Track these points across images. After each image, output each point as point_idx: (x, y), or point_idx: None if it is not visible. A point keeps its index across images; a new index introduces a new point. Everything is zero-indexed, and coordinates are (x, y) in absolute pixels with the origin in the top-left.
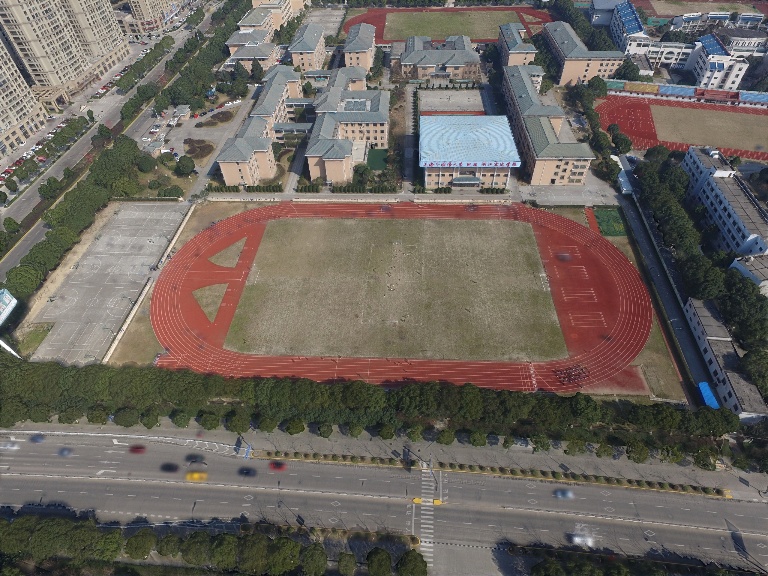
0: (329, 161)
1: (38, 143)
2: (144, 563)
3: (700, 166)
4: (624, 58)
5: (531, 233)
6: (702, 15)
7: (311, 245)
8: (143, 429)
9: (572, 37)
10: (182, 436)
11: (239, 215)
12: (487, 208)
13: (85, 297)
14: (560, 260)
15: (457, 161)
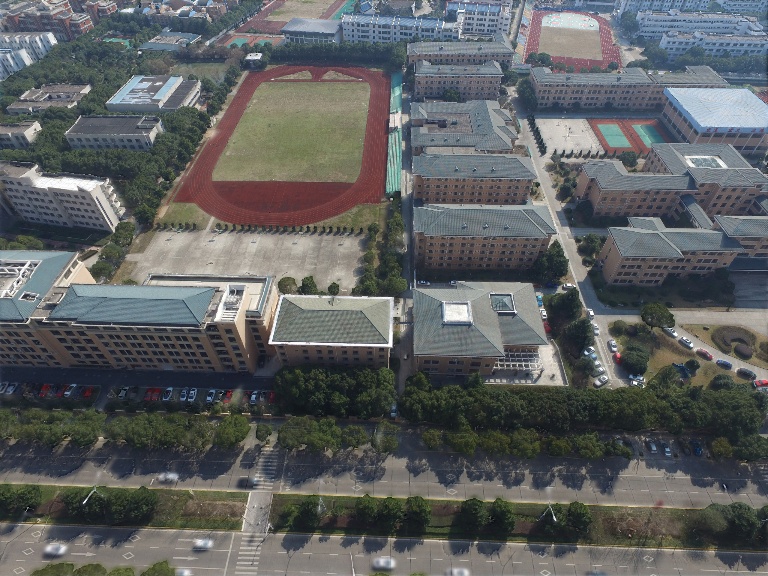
0: None
1: None
2: None
3: (691, 41)
4: None
5: None
6: (361, 4)
7: None
8: None
9: (475, 42)
10: None
11: None
12: None
13: None
14: None
15: None
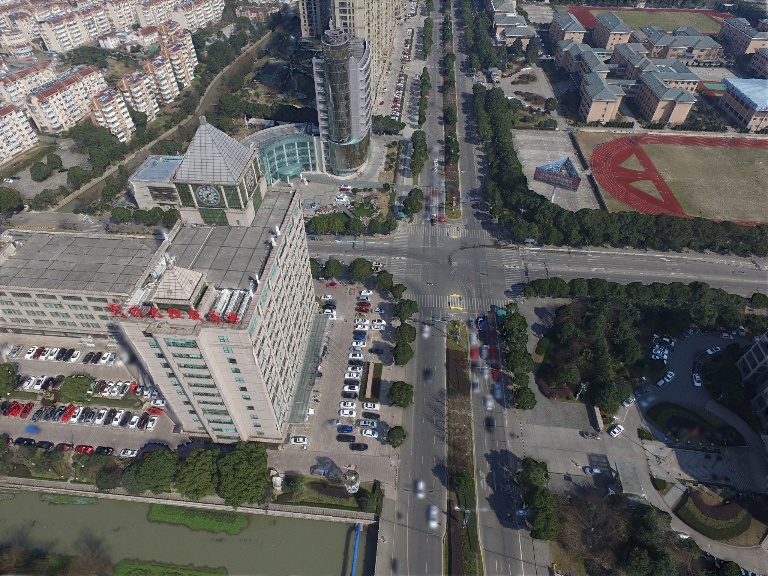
0: (680, 104)
1: (398, 89)
2: (760, 313)
3: None
4: None
5: None
6: None
7: (691, 161)
8: (678, 254)
9: None
10: (710, 258)
11: (614, 141)
12: None
13: None
14: None
15: None
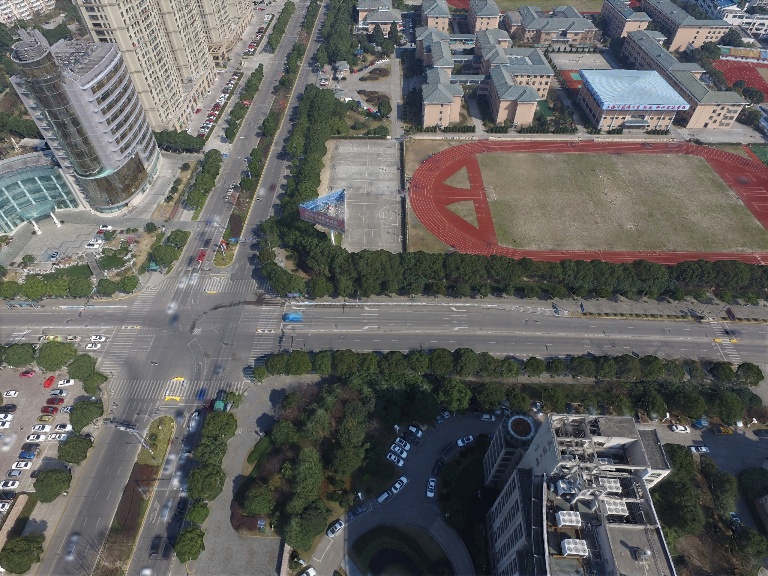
0: (522, 104)
1: (224, 92)
2: (536, 381)
3: None
4: (730, 26)
5: (706, 164)
6: None
7: (526, 172)
8: (471, 300)
9: None
10: (506, 304)
11: (448, 150)
12: (659, 145)
13: (355, 211)
14: (740, 183)
15: (636, 104)
